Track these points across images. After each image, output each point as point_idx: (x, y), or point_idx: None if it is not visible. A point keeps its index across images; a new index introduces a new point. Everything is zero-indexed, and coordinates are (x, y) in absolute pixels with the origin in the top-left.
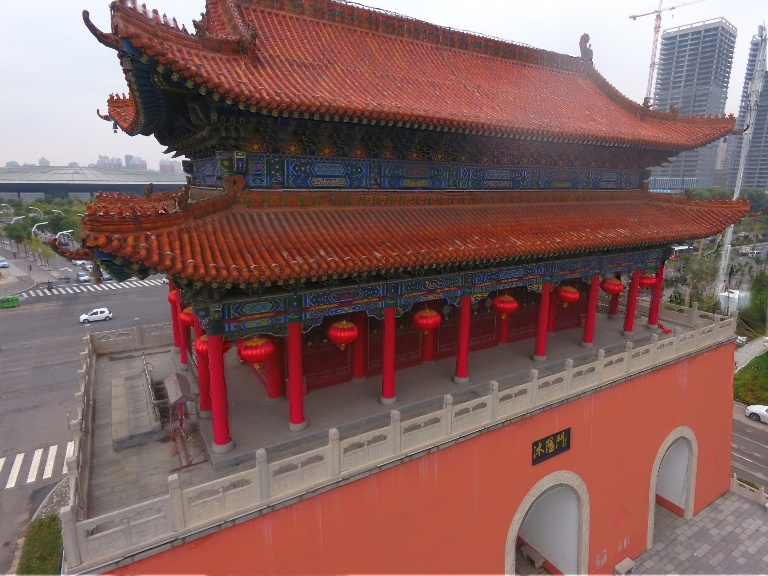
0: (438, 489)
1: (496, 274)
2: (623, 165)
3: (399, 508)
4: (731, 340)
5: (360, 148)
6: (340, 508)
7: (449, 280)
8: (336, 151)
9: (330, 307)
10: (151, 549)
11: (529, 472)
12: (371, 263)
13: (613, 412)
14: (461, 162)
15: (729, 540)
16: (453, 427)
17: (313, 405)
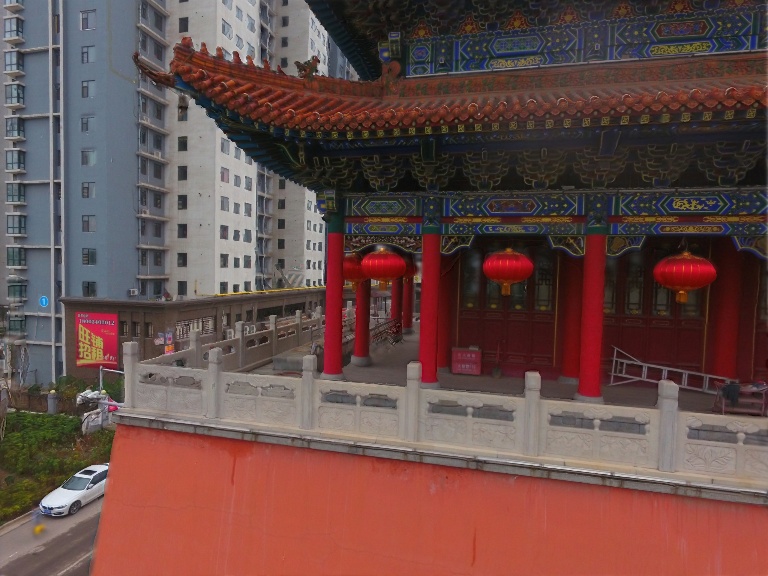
0: None
1: None
2: None
3: None
4: None
5: None
6: None
7: None
8: None
9: None
10: None
11: None
12: None
13: None
14: None
15: None
16: None
17: None
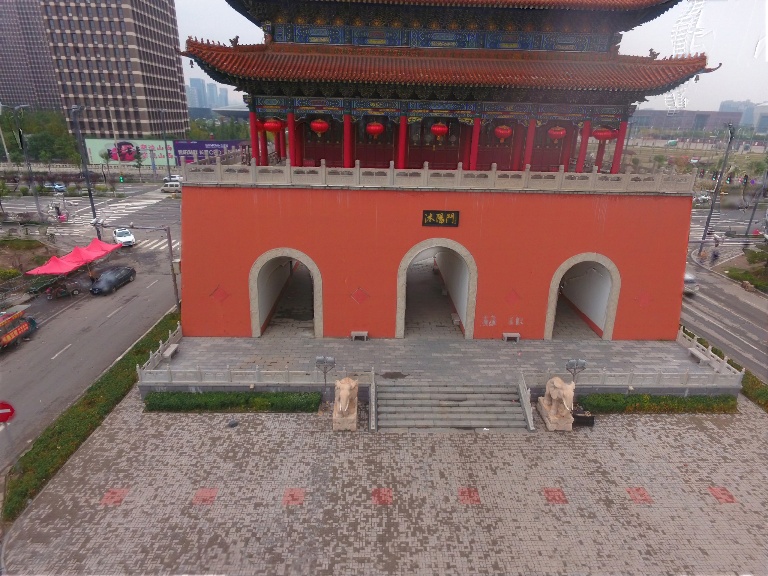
0: (349, 214)
1: (427, 105)
2: (588, 30)
3: (324, 215)
4: (682, 194)
5: (339, 19)
6: (290, 200)
7: (388, 104)
8: (324, 21)
9: (310, 109)
10: (209, 184)
11: (420, 229)
12: (310, 75)
13: (506, 214)
14: (412, 28)
15: (622, 353)
16: (361, 181)
17: (312, 172)
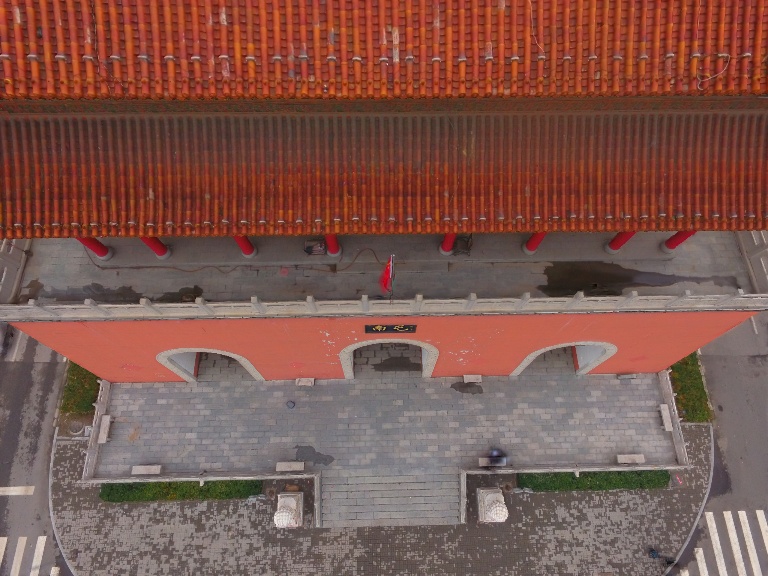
0: None
1: None
2: None
3: None
4: None
5: None
6: None
7: None
8: None
9: None
10: None
11: None
12: None
13: None
14: None
15: None
16: None
17: None
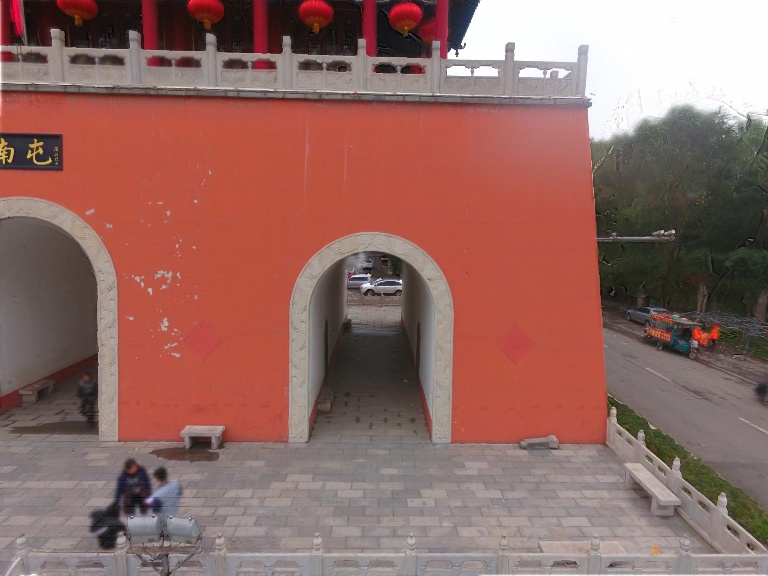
0: None
1: None
2: None
3: None
4: None
5: None
6: None
7: None
8: None
9: None
10: None
11: None
12: None
13: None
14: None
15: None
16: None
17: None
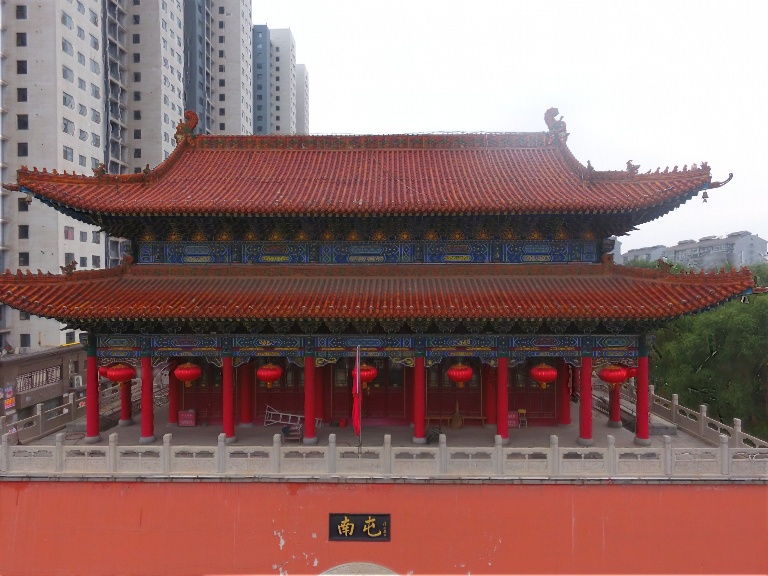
0: None
1: None
2: None
3: None
4: None
5: None
6: None
7: None
8: None
9: None
10: None
11: None
12: None
13: None
14: None
15: None
16: None
17: None
